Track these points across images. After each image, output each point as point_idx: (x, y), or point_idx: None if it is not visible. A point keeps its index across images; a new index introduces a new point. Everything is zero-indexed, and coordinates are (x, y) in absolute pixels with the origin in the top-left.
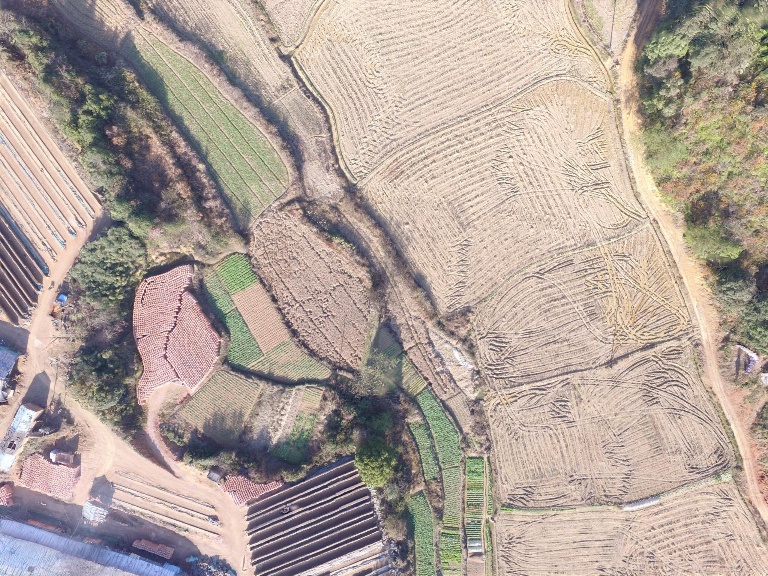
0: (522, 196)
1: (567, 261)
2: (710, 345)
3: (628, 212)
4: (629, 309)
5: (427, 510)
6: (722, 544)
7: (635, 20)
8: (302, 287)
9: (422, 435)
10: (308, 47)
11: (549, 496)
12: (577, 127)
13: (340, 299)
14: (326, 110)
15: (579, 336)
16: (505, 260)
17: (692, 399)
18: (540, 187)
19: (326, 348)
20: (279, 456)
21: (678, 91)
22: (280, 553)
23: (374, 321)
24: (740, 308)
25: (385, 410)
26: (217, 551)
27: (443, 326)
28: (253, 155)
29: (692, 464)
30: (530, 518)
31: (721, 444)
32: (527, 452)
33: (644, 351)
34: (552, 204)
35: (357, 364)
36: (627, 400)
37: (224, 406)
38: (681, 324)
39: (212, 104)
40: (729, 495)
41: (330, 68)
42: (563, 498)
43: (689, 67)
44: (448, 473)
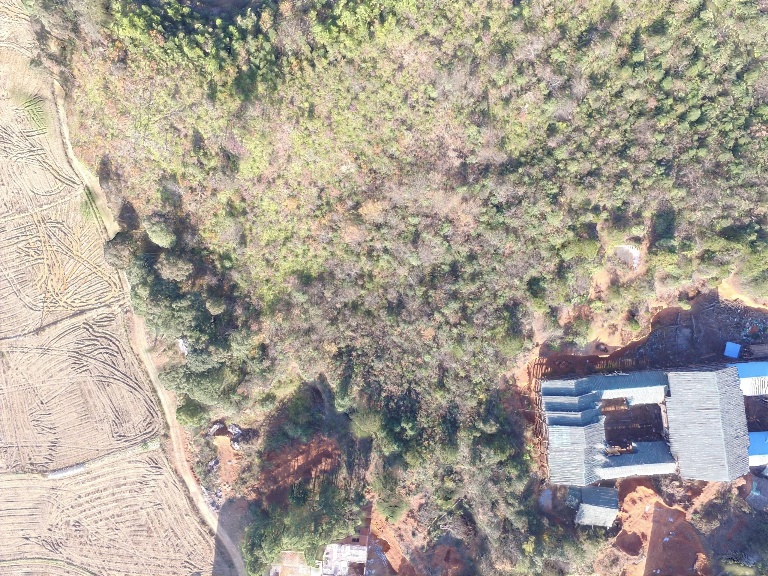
0: None
1: None
2: None
3: (63, 179)
4: (60, 276)
5: None
6: (150, 513)
7: None
8: None
9: None
10: None
11: None
12: (14, 94)
13: None
14: None
15: (9, 303)
16: None
17: (122, 367)
18: None
19: None
20: None
21: (37, 52)
22: None
23: None
24: None
25: None
26: None
27: None
28: None
29: (120, 432)
30: None
31: (151, 412)
32: None
33: (72, 318)
34: None
35: None
36: (55, 368)
37: None
38: (113, 291)
39: None
40: (158, 464)
41: None
42: None
43: None
44: None
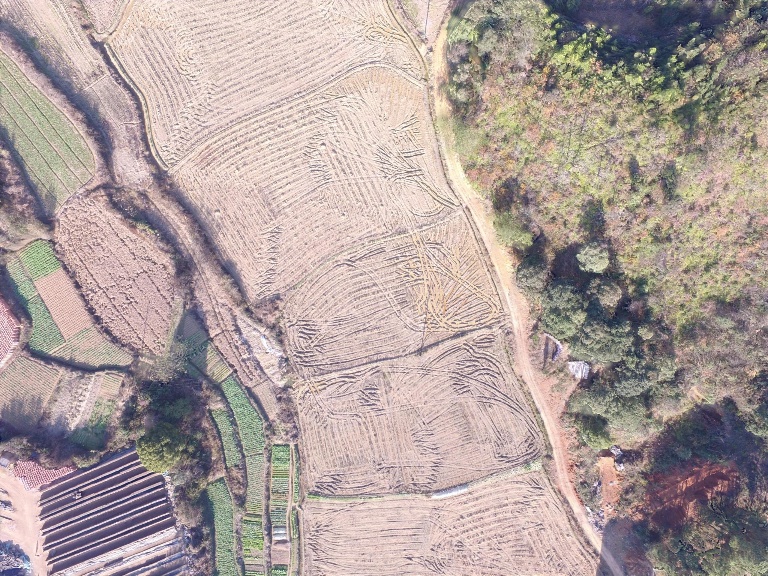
0: (334, 183)
1: (379, 249)
2: (521, 333)
3: (441, 200)
4: (440, 297)
5: (227, 497)
6: (532, 533)
7: (449, 7)
8: (106, 274)
9: (224, 422)
10: (122, 34)
11: (357, 484)
12: (391, 114)
13: (143, 286)
14: (139, 97)
15: (389, 324)
16: (316, 247)
17: (503, 388)
18: (352, 174)
19: (129, 335)
20: (77, 442)
21: (467, 76)
22: (71, 539)
23: (178, 308)
24: (537, 295)
25: (184, 397)
26: (11, 536)
27: (251, 313)
28: (60, 142)
29: (502, 453)
30: (338, 506)
31: (532, 433)
32: (335, 440)
33: (454, 339)
34: (364, 191)
35: (160, 351)
36: (437, 388)
37: (23, 392)
38: (493, 312)
39: (20, 91)
40: (539, 484)
41: (143, 55)
42: (371, 486)
43: (477, 52)
44: (251, 460)
